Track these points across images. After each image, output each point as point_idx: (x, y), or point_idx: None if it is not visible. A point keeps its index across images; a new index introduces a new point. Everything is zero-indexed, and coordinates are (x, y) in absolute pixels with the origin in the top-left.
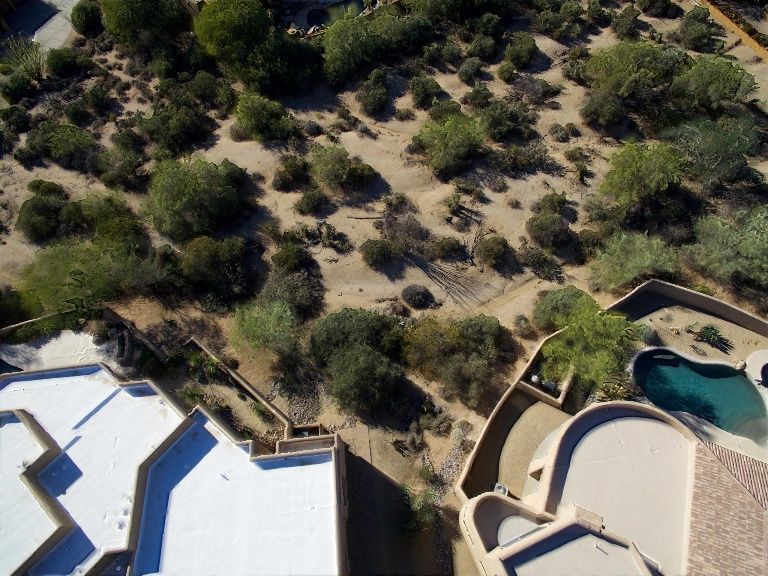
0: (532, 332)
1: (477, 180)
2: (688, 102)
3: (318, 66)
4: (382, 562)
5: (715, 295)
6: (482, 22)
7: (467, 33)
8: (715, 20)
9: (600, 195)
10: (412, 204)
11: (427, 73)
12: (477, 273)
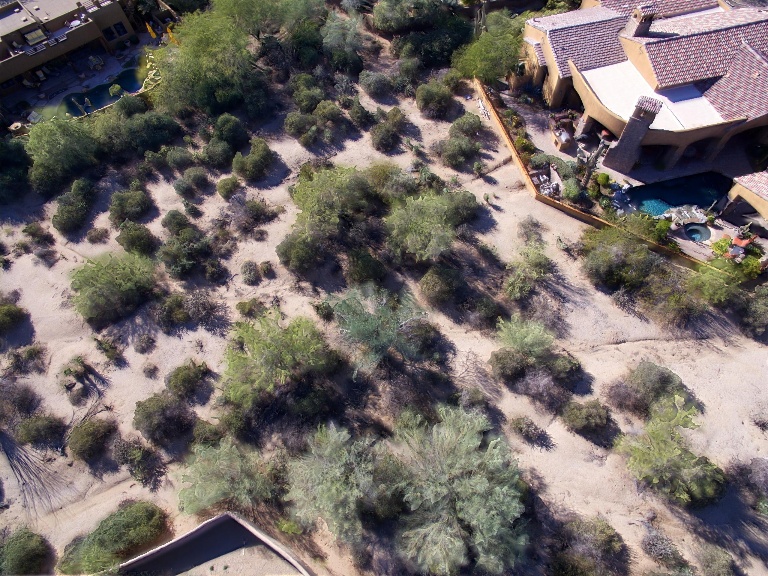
0: (76, 566)
1: (128, 333)
2: (392, 249)
3: (26, 170)
4: None
5: (319, 531)
6: (216, 124)
7: (207, 133)
8: (493, 128)
9: None
10: (42, 361)
11: (150, 181)
12: (64, 467)
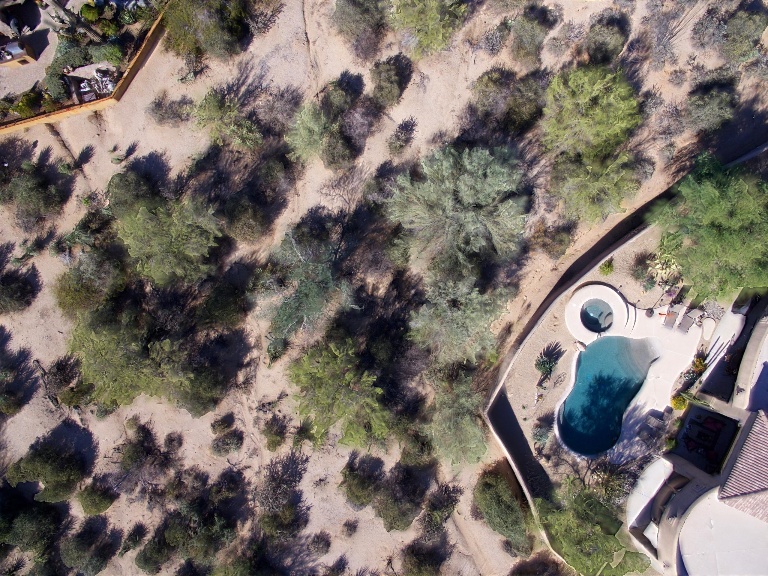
0: (527, 542)
1: (306, 569)
2: None
3: None
4: None
5: (491, 331)
6: None
7: None
8: None
9: None
10: None
11: None
12: None
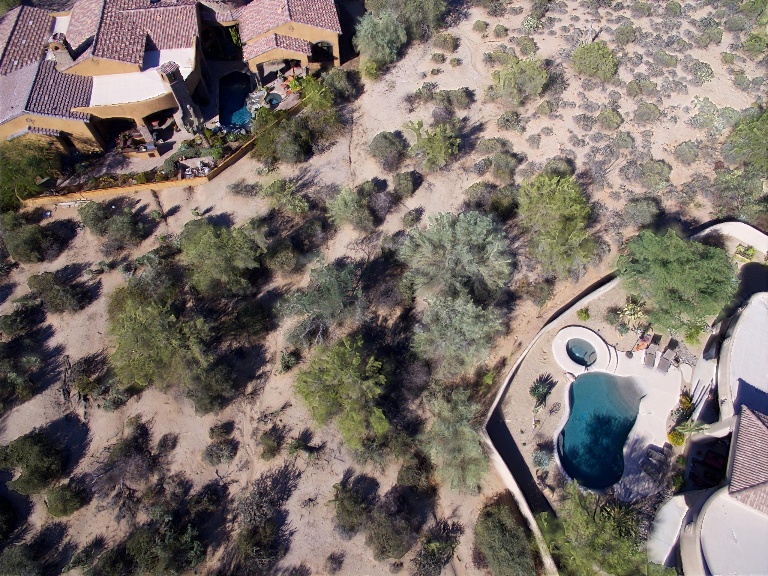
0: None
1: None
2: (239, 288)
3: None
4: None
5: (487, 363)
6: None
7: None
8: (107, 199)
9: (342, 436)
10: None
11: None
12: None
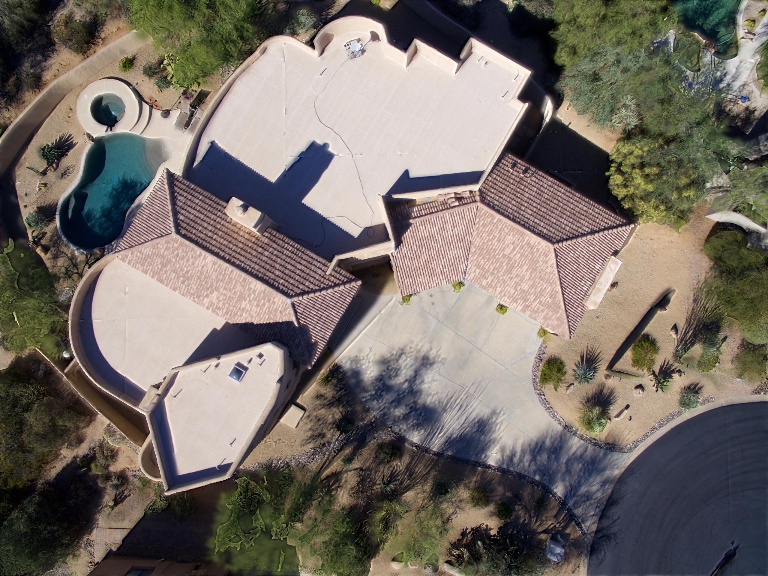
0: None
1: None
2: None
3: None
4: (212, 532)
5: (12, 120)
6: None
7: None
8: None
9: None
10: None
11: None
12: None
